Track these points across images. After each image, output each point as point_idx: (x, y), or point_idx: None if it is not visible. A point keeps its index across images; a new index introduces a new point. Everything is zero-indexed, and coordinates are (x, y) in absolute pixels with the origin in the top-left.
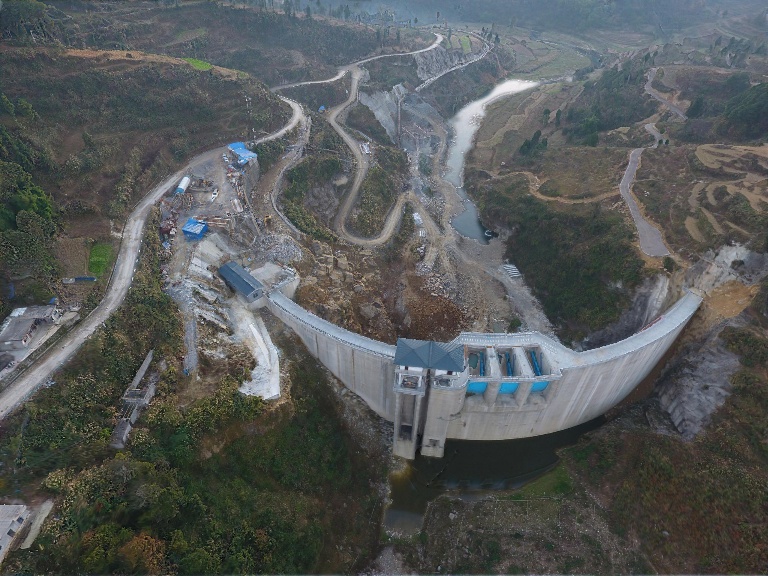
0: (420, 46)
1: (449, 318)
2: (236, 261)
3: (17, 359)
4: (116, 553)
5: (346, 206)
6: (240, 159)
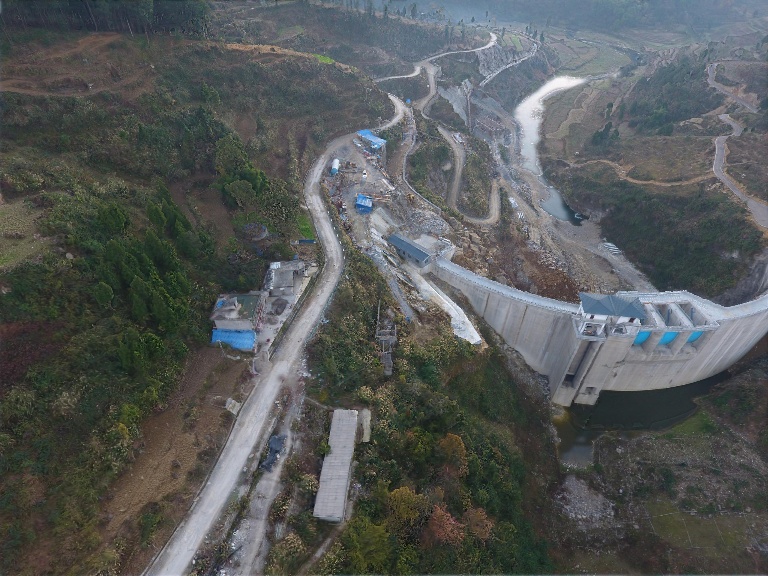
0: (480, 44)
1: (569, 288)
2: (399, 232)
3: (291, 302)
4: (433, 448)
5: (454, 190)
6: (373, 144)
